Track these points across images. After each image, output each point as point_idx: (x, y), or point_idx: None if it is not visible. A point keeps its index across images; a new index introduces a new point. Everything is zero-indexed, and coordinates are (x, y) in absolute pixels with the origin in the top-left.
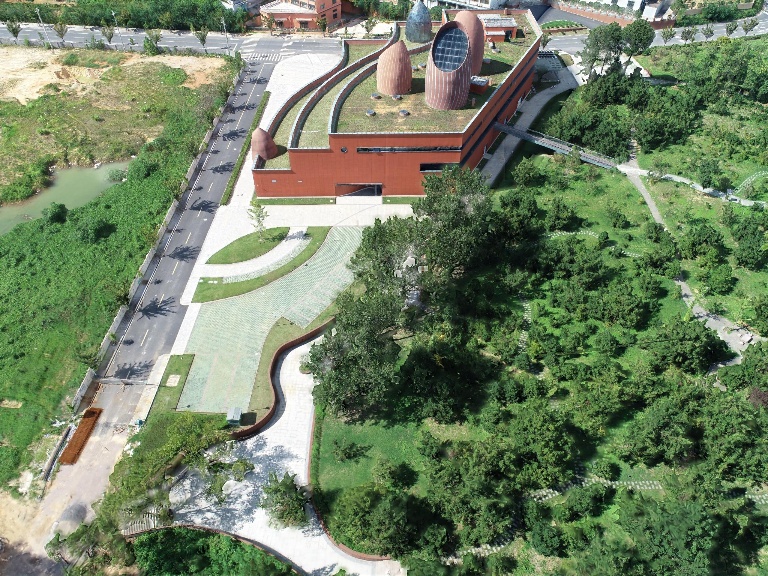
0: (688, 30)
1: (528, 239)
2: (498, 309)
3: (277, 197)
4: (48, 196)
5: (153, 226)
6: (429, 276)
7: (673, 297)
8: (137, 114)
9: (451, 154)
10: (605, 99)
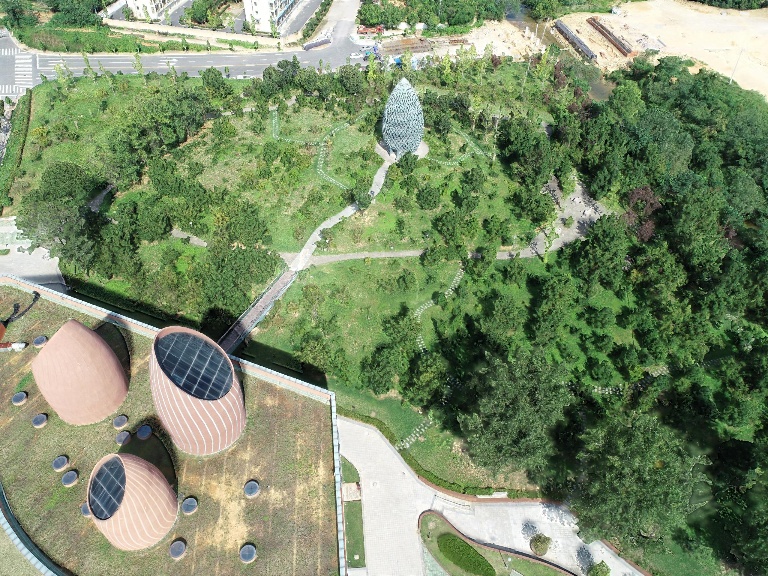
0: None
1: None
2: None
3: None
4: None
5: None
6: None
7: None
8: None
9: None
10: None
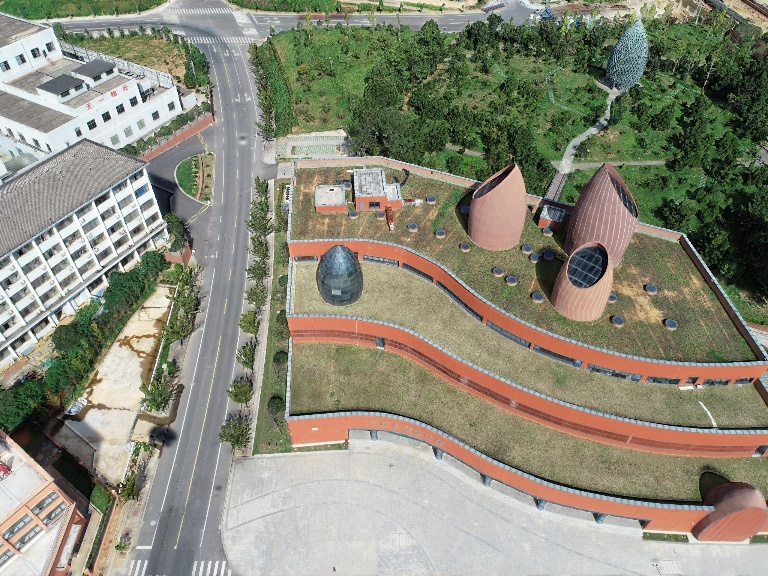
0: (263, 84)
1: None
2: None
3: None
4: None
5: None
6: None
7: None
8: None
9: None
10: None
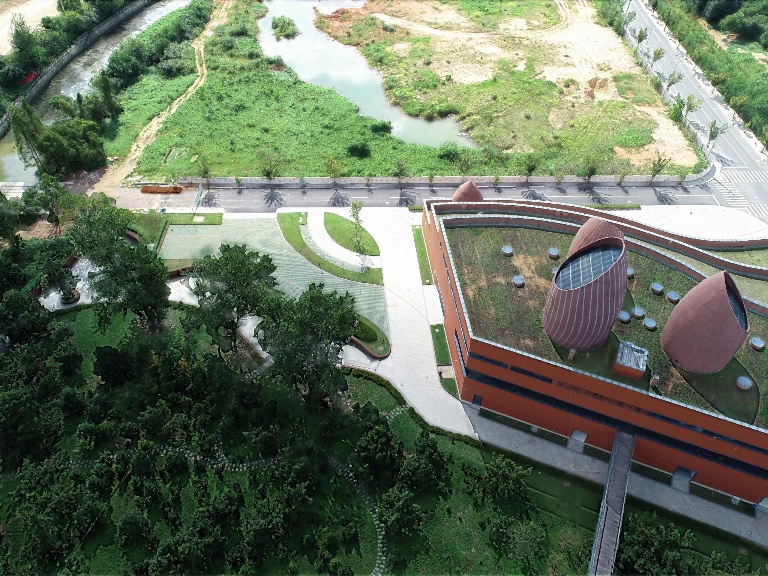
0: None
1: None
2: None
3: None
4: (416, 123)
5: (369, 174)
6: (197, 310)
7: None
8: (547, 133)
9: None
10: None
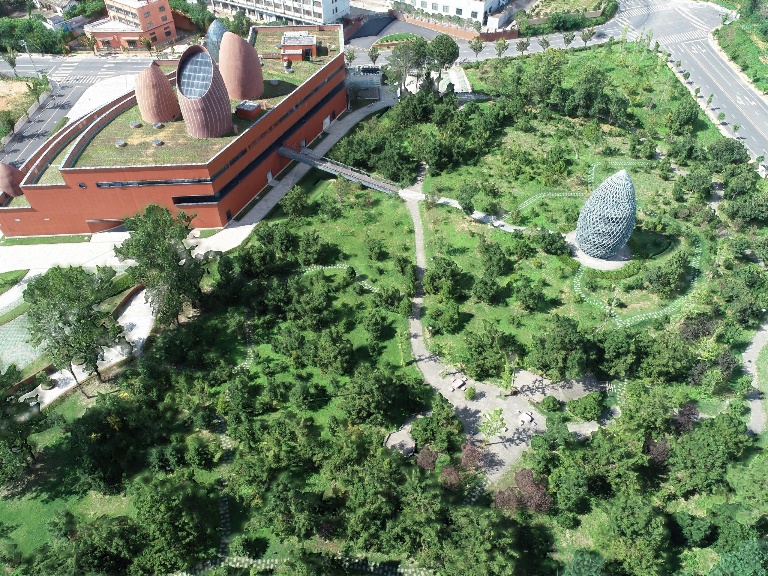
0: (522, 41)
1: (279, 275)
2: (208, 359)
3: (27, 236)
4: None
5: None
6: None
7: (398, 338)
8: None
9: (202, 186)
10: (414, 117)
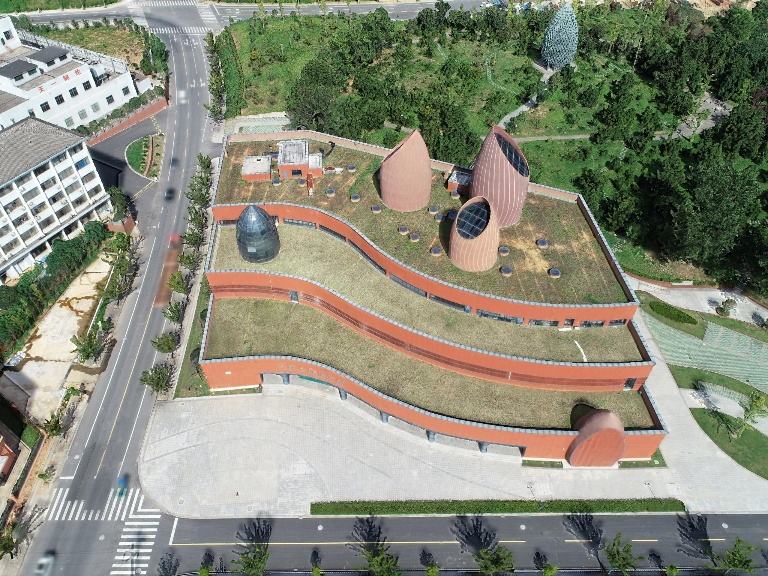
0: (215, 69)
1: None
2: None
3: None
4: None
5: None
6: None
7: None
8: None
9: None
10: None
